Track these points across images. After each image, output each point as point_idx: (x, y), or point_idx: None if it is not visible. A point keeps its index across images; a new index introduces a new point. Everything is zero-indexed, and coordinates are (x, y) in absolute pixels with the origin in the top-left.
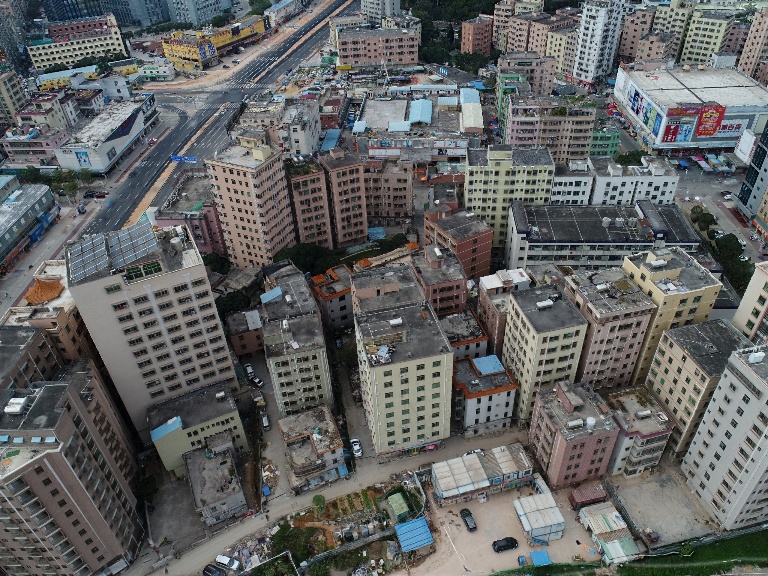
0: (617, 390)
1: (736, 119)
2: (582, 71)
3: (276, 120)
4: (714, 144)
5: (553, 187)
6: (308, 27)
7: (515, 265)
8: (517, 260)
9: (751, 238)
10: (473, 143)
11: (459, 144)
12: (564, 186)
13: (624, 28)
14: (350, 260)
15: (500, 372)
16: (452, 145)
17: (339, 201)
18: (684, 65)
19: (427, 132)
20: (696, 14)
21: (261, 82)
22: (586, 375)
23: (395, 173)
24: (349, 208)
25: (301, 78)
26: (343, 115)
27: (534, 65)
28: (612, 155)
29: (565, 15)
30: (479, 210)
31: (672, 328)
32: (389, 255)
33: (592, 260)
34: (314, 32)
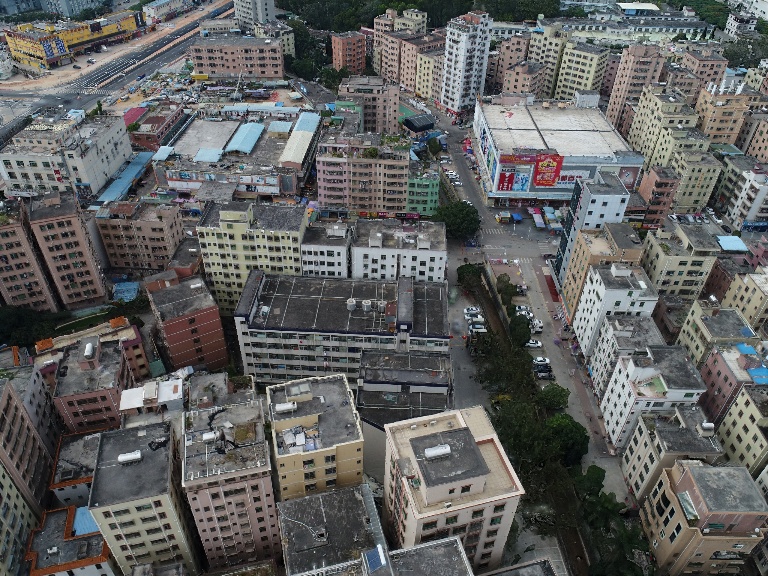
0: (235, 569)
1: (576, 170)
2: (448, 99)
3: (55, 142)
4: (554, 195)
5: (302, 256)
6: (190, 27)
7: (242, 351)
8: (243, 346)
9: (554, 317)
10: (286, 180)
11: (268, 181)
12: (315, 255)
13: (500, 54)
14: (73, 327)
15: (96, 534)
16: (261, 181)
17: (51, 258)
18: (544, 102)
19: (236, 164)
20: (569, 45)
21: (106, 88)
22: (206, 542)
23: (147, 221)
24: (68, 265)
25: (152, 86)
26: (169, 134)
27: (375, 93)
28: (433, 204)
29: (441, 35)
30: (221, 276)
31: (308, 490)
32: (90, 332)
33: (329, 351)
34: (194, 33)
